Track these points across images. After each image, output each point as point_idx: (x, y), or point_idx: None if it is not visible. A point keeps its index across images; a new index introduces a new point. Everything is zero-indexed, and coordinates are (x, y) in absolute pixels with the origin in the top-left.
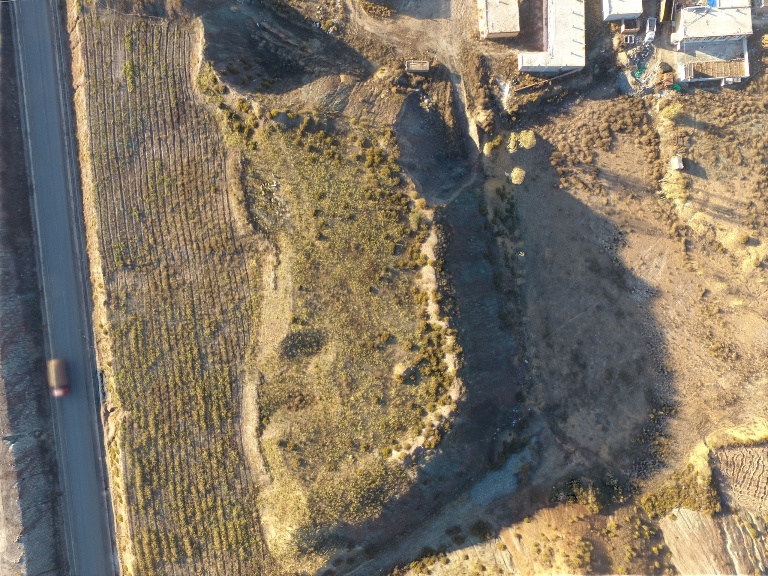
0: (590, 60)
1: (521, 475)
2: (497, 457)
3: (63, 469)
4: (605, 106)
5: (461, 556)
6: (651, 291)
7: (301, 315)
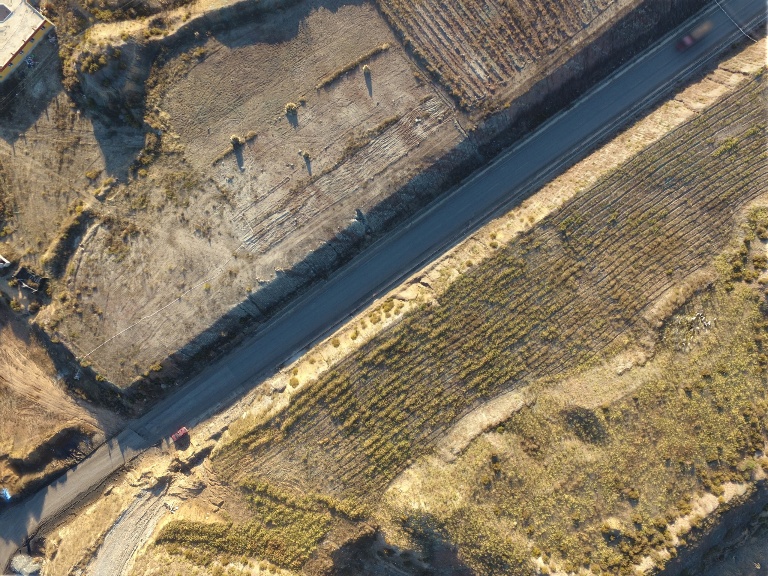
0: None
1: None
2: None
3: (347, 268)
4: None
5: None
6: None
7: (613, 412)
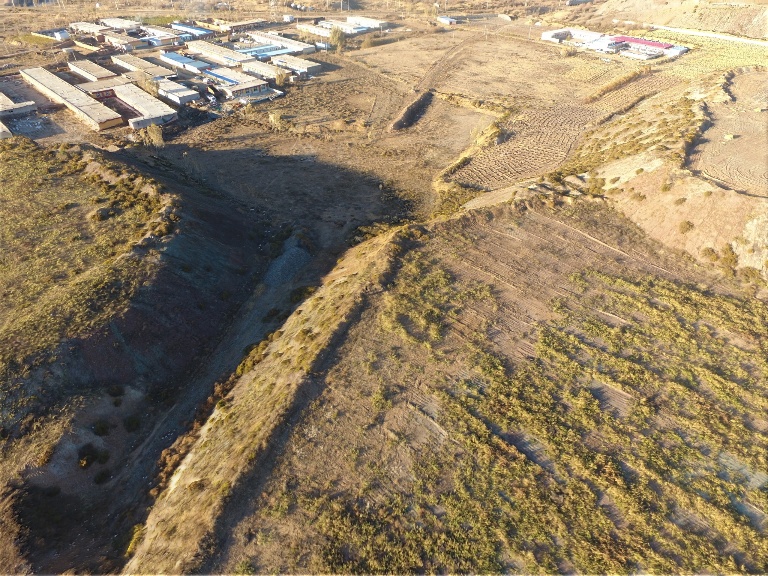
0: None
1: (301, 241)
2: (271, 251)
3: None
4: (209, 124)
5: (293, 317)
6: (314, 156)
7: None
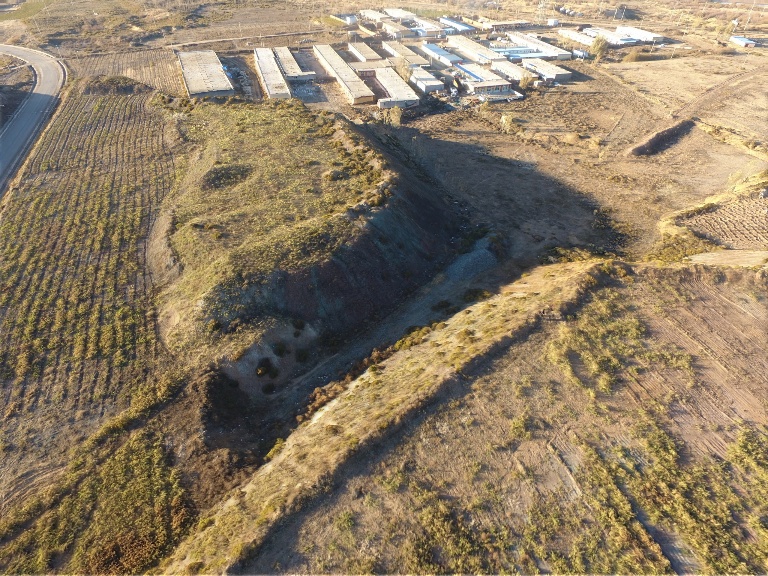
0: None
1: (493, 245)
2: (461, 246)
3: None
4: (443, 115)
5: (461, 315)
6: (534, 164)
7: (224, 161)
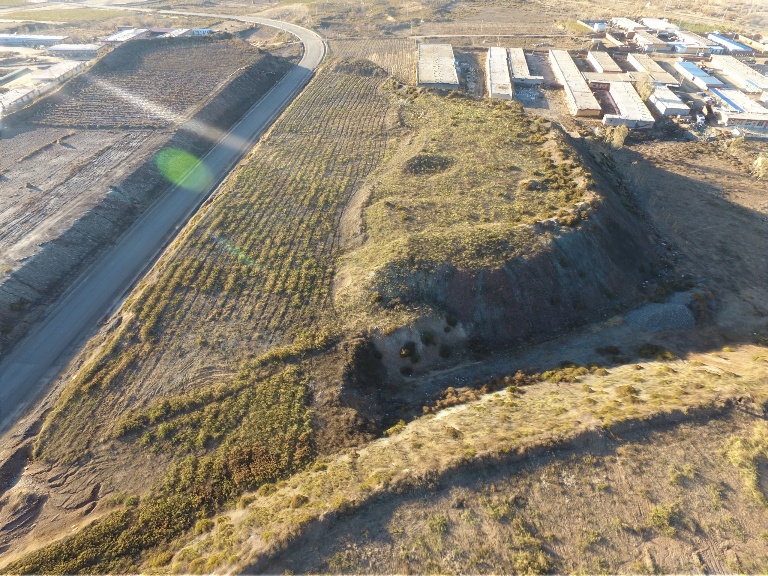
0: (658, 127)
1: (696, 303)
2: (654, 293)
3: (133, 230)
4: None
5: (629, 368)
6: None
7: (430, 150)
